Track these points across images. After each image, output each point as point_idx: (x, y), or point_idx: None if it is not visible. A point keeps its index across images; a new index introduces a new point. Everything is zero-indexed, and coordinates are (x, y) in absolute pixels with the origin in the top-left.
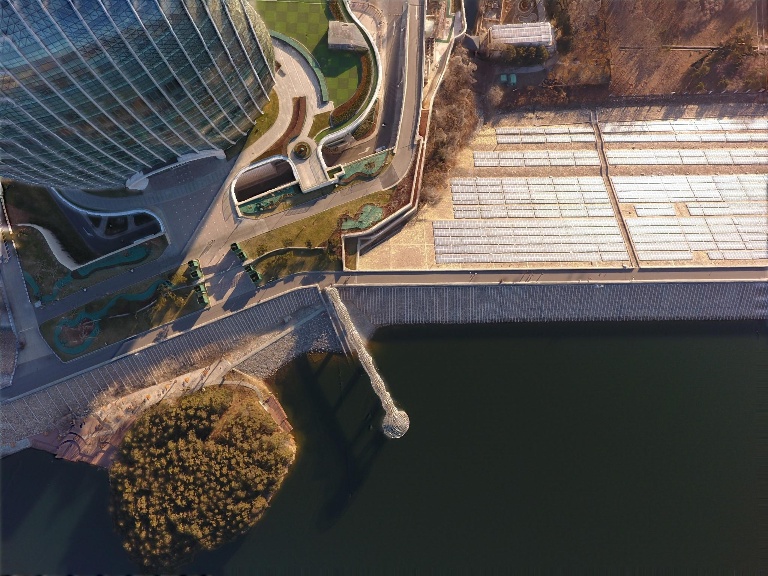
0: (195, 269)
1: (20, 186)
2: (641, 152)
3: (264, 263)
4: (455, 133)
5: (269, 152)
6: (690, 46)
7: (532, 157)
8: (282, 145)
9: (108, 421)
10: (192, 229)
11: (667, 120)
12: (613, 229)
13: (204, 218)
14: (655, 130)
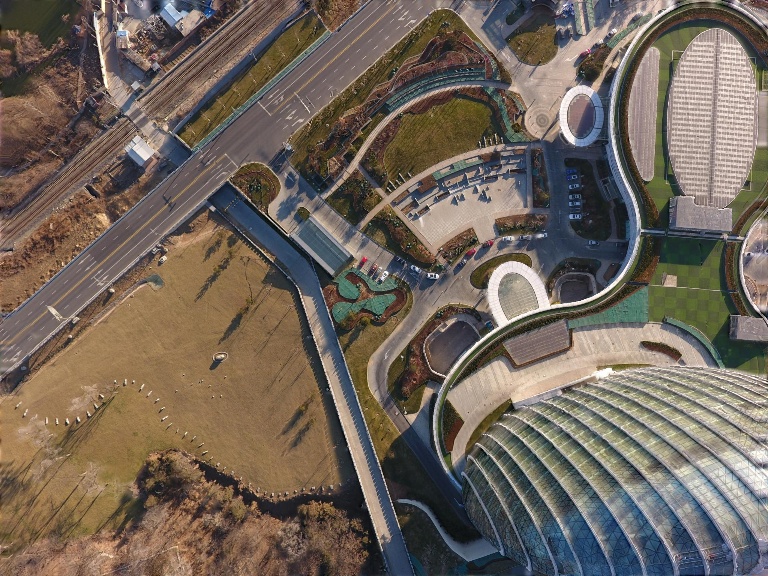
0: None
1: (395, 457)
2: None
3: None
4: None
5: None
6: None
7: None
8: None
9: None
10: None
11: None
12: None
13: None
14: None
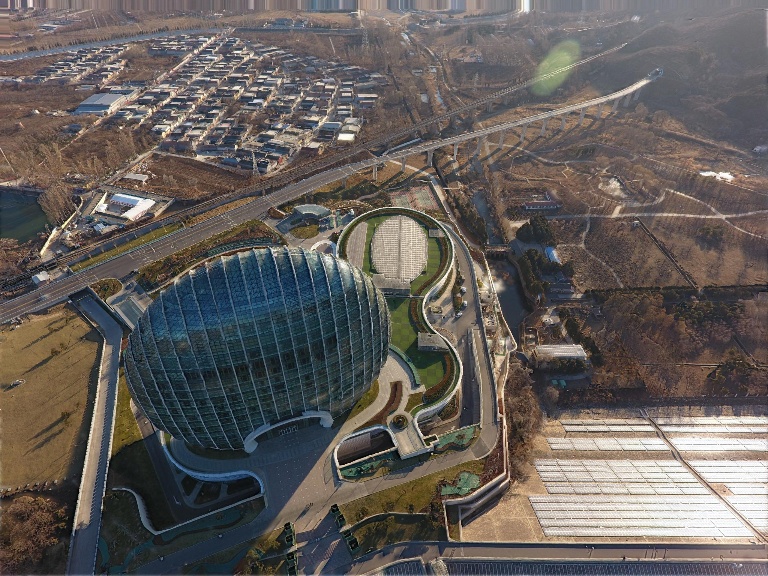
0: (290, 533)
1: (128, 454)
2: (703, 440)
3: (362, 530)
4: (528, 417)
5: (370, 422)
6: (698, 364)
7: (603, 443)
8: (382, 417)
9: None
10: (291, 491)
11: (711, 417)
12: (717, 505)
13: (305, 480)
14: (705, 423)
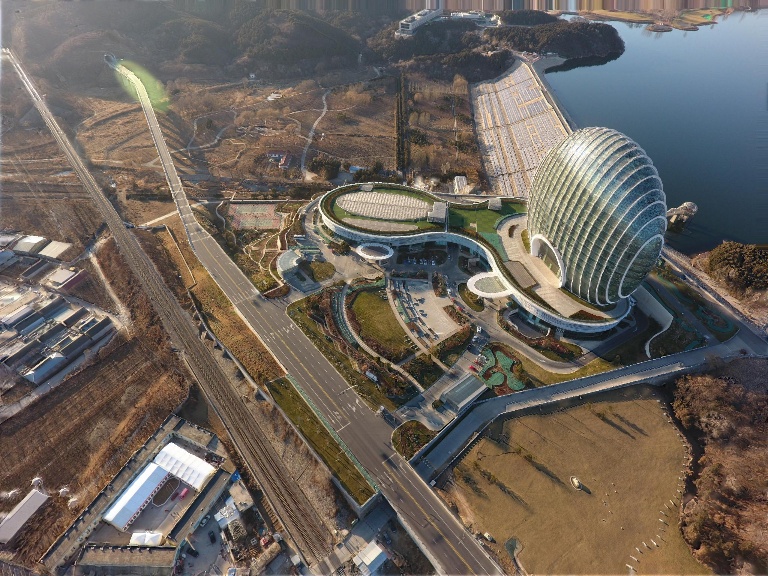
0: None
1: None
2: None
3: None
4: None
5: None
6: None
7: (521, 188)
8: None
9: (764, 321)
10: None
11: None
12: None
13: None
14: None
